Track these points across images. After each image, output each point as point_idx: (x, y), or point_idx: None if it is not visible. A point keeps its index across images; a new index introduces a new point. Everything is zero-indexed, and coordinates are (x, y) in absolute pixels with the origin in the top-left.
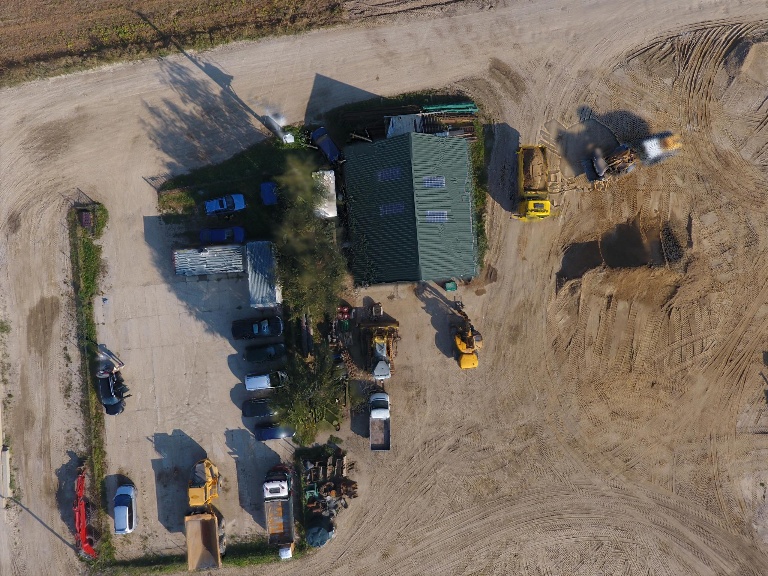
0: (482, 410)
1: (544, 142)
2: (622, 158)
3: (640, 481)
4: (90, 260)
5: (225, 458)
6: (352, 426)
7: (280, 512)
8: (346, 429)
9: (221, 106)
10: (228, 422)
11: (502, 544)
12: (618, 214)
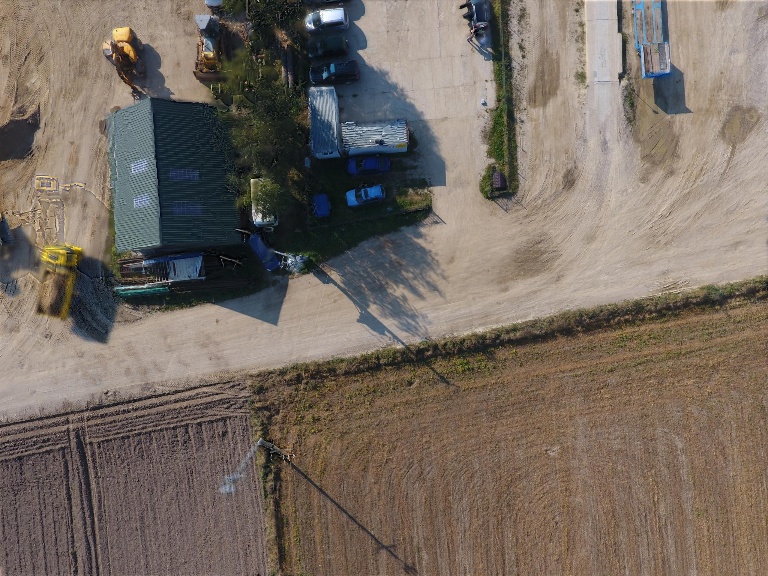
0: None
1: (52, 260)
2: None
3: None
4: (498, 143)
5: None
6: None
7: None
8: None
9: (369, 293)
10: None
11: None
12: None
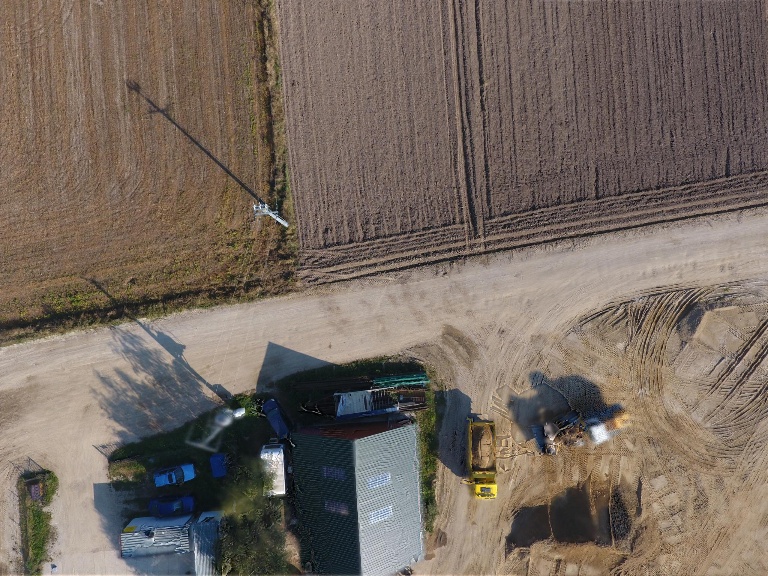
0: None
1: (496, 408)
2: (571, 436)
3: None
4: (39, 527)
5: None
6: None
7: None
8: None
9: (173, 375)
10: None
11: None
12: (568, 478)
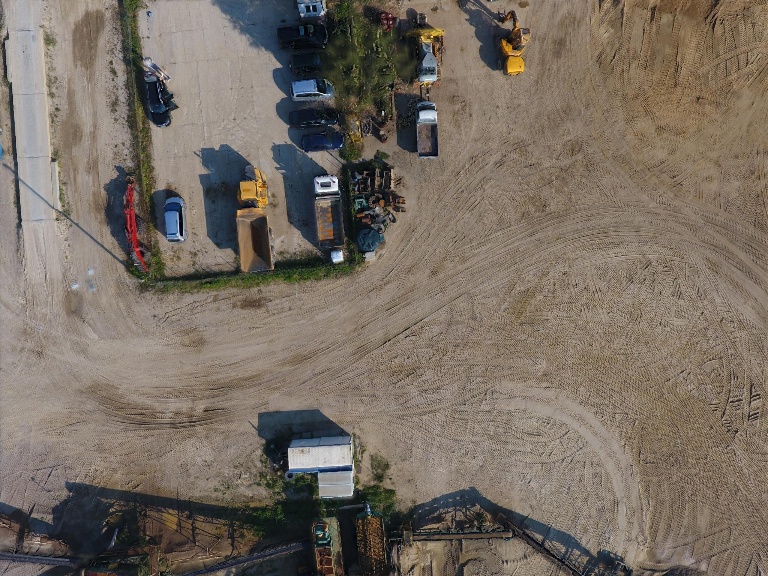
0: (528, 125)
1: None
2: None
3: (688, 198)
4: None
5: (272, 173)
6: (398, 141)
7: (330, 218)
8: (392, 144)
9: None
10: (275, 137)
11: (551, 262)
12: None
